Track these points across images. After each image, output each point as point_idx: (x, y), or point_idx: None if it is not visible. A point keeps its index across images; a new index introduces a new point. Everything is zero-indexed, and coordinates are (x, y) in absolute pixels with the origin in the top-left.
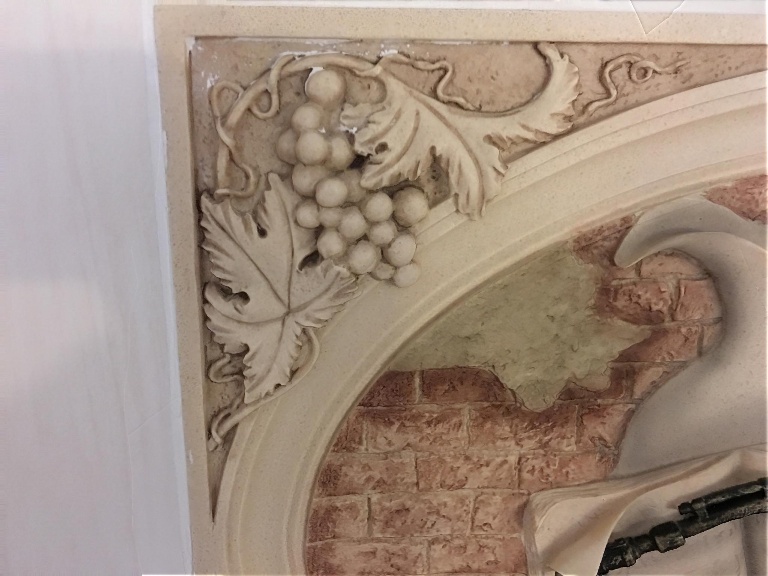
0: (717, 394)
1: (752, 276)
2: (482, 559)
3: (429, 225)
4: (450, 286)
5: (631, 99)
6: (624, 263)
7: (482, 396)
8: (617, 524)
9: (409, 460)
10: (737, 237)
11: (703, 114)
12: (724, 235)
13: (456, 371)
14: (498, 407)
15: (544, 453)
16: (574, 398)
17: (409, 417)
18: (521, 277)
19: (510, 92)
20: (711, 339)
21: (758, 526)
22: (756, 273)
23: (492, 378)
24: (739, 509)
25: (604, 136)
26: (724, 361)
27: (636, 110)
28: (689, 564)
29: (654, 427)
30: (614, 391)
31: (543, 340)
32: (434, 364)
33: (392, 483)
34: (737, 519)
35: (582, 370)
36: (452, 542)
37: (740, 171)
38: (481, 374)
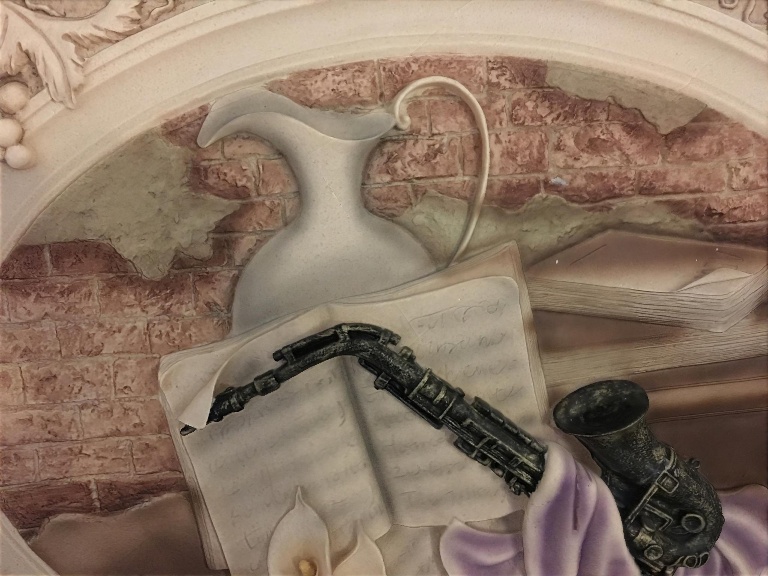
0: (298, 255)
1: (306, 150)
2: (129, 422)
3: (31, 112)
4: (65, 170)
5: (187, 6)
6: (203, 143)
7: (106, 267)
8: (232, 377)
9: (49, 328)
10: (283, 115)
11: (245, 17)
12: (272, 114)
13: (79, 245)
14: (121, 277)
15: (169, 319)
16: (185, 266)
17: (44, 288)
18: (120, 158)
19: (88, 2)
20: (293, 210)
21: (355, 375)
22: (307, 147)
23: (112, 251)
24: (319, 351)
25: (165, 35)
26: (302, 227)
27: (187, 13)
28: (297, 411)
29: (253, 288)
30: (218, 259)
31: (149, 214)
32: (57, 238)
33: (37, 351)
34: (336, 369)
35: (186, 240)
36: (99, 406)
37: (290, 66)
38: (101, 247)
